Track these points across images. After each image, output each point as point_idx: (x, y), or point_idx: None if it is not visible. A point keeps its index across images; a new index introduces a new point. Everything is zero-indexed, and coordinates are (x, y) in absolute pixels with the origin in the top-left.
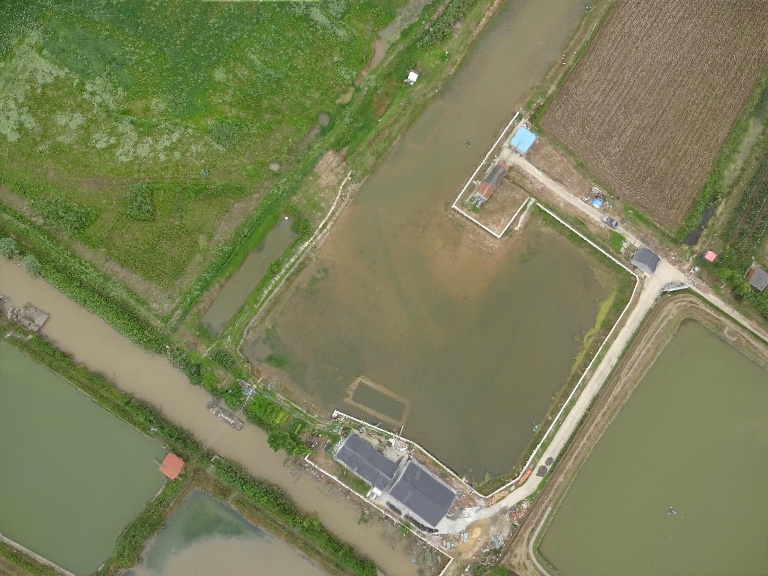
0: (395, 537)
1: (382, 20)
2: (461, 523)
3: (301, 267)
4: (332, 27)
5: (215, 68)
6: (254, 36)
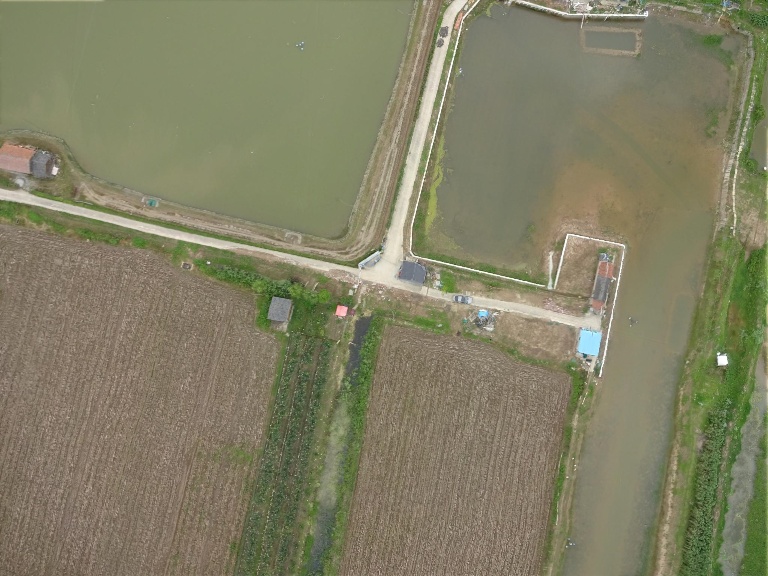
0: None
1: None
2: None
3: (732, 129)
4: None
5: None
6: None
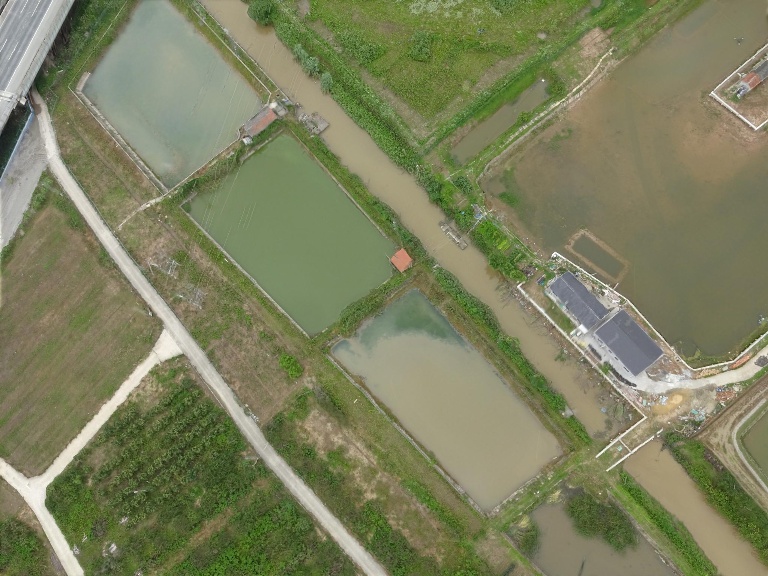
0: (589, 383)
1: None
2: (662, 386)
3: (548, 123)
4: None
5: None
6: None
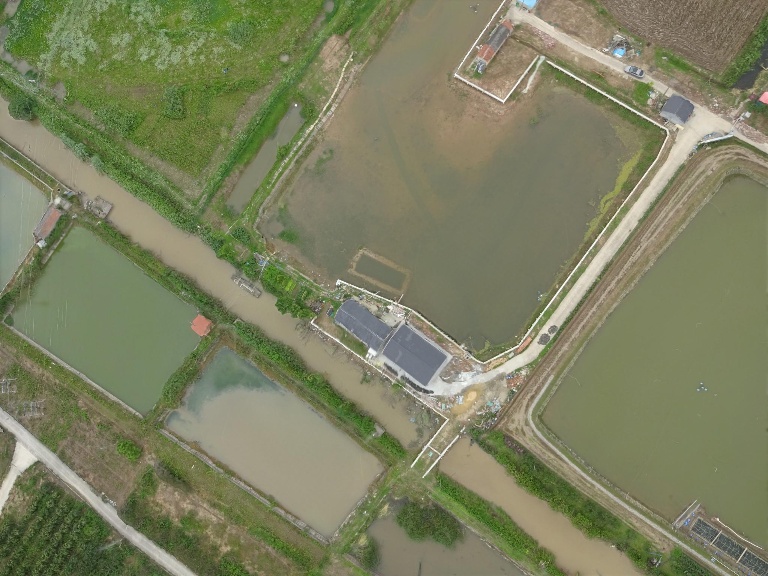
0: (395, 397)
1: None
2: (457, 386)
3: (309, 149)
4: None
5: None
6: None
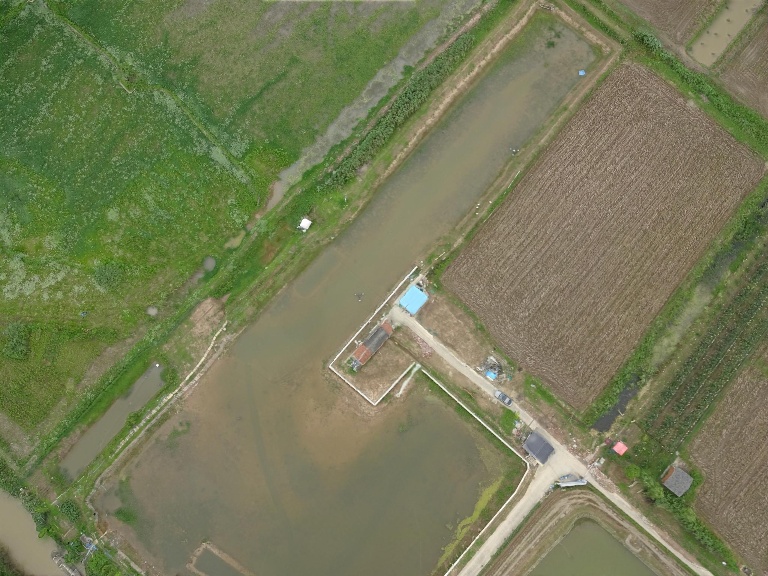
0: None
1: (284, 161)
2: None
3: (163, 418)
4: (231, 168)
5: (109, 207)
6: (152, 175)
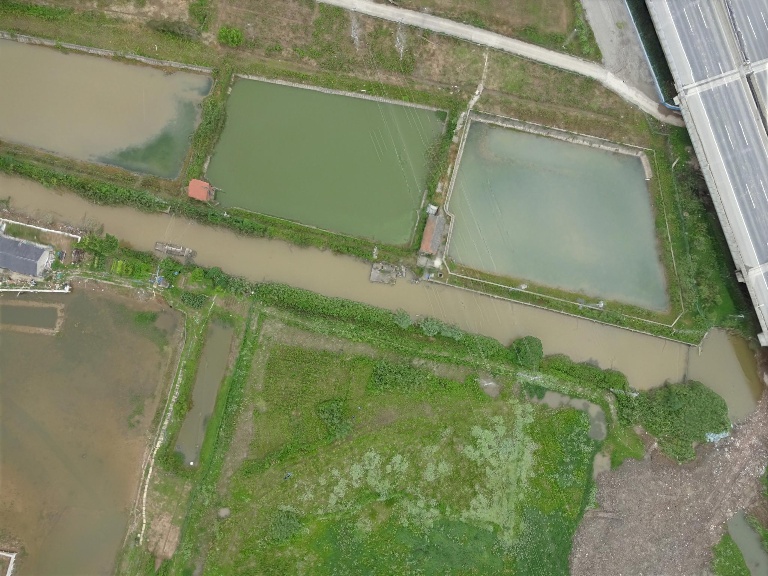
0: None
1: None
2: None
3: (157, 419)
4: None
5: None
6: None
